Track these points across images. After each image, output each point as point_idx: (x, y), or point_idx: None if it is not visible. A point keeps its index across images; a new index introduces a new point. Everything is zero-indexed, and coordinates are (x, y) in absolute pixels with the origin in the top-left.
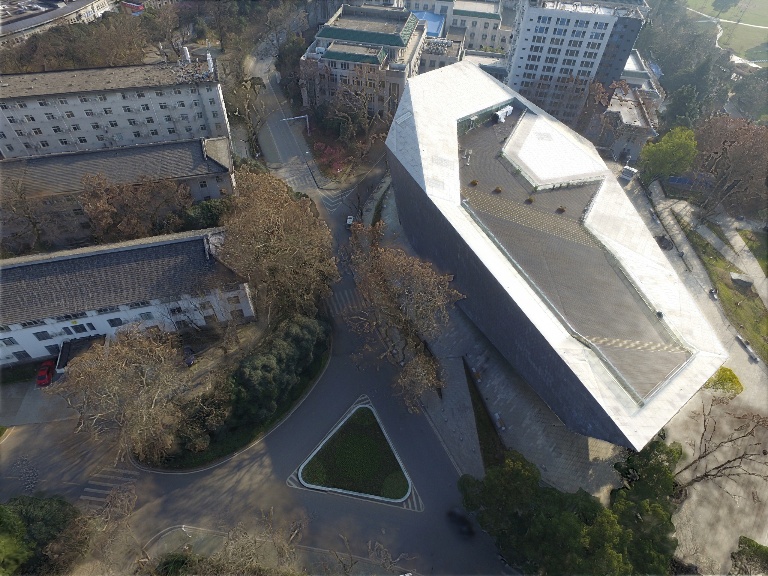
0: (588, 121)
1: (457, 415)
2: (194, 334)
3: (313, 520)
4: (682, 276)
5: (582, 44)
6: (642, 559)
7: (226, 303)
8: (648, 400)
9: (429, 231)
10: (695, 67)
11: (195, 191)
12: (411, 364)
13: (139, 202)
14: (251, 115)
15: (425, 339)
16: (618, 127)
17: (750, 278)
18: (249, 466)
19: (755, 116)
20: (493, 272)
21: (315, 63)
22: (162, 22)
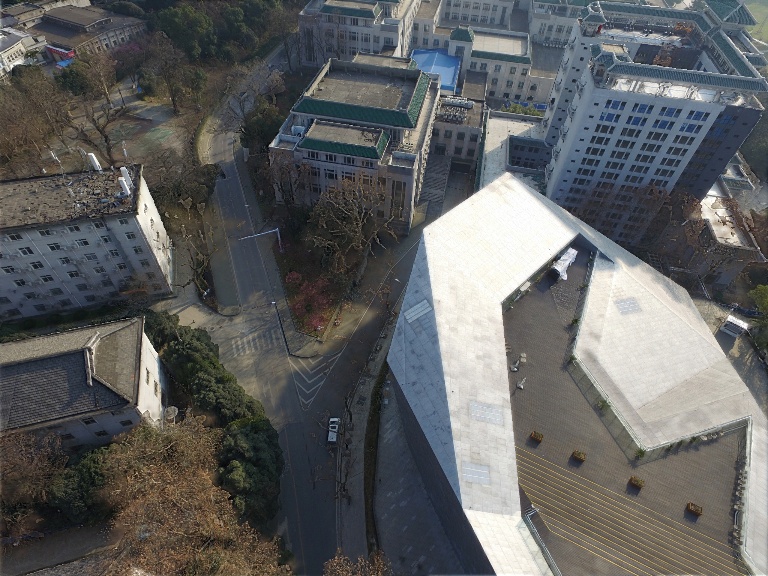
0: (662, 228)
1: None
2: None
3: None
4: None
5: (667, 137)
6: None
7: None
8: None
9: (462, 536)
10: None
11: (77, 429)
12: None
13: None
14: None
15: None
16: (710, 248)
17: None
18: None
19: None
20: None
21: (288, 158)
22: (92, 79)
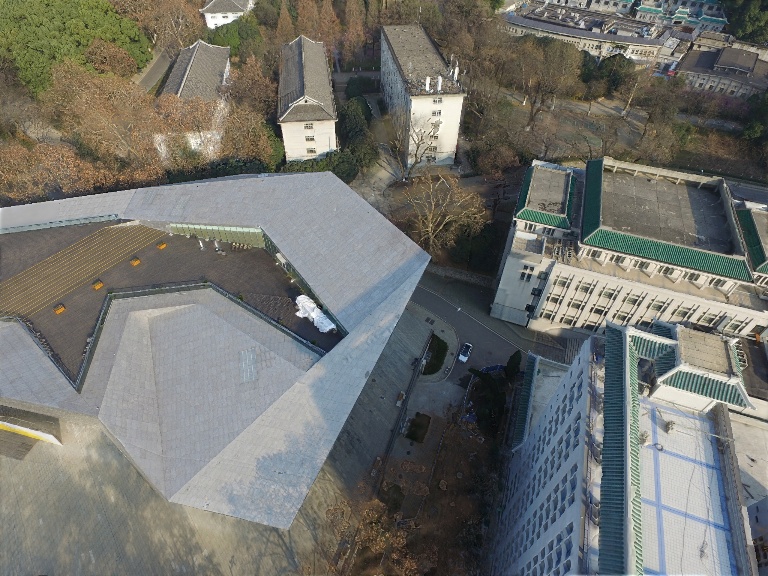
0: None
1: None
2: None
3: None
4: None
5: None
6: None
7: None
8: None
9: None
10: None
11: None
12: None
13: None
14: None
15: None
16: None
17: None
18: None
19: None
20: (5, 209)
21: (506, 163)
22: None
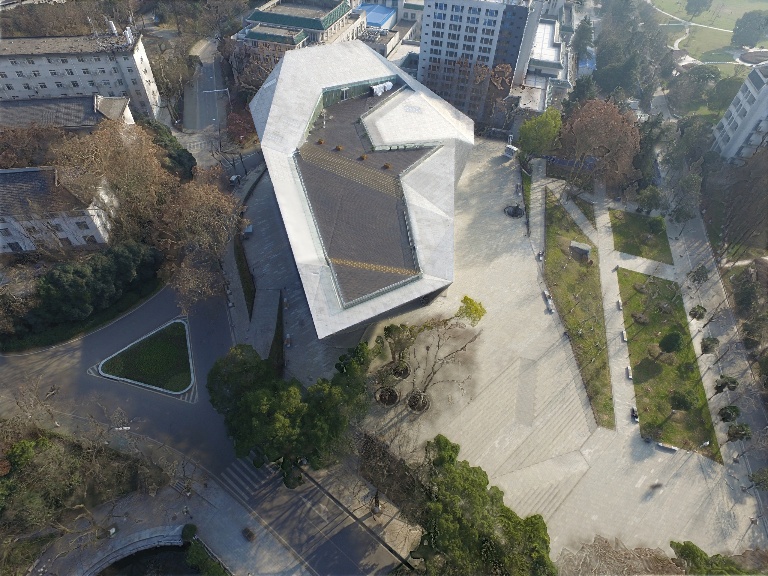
0: None
1: (259, 335)
2: (51, 254)
3: (98, 400)
4: (519, 240)
5: (477, 30)
6: (310, 428)
7: (76, 227)
8: (348, 303)
9: None
10: (624, 62)
11: None
12: (182, 271)
13: (18, 140)
14: (186, 89)
15: (254, 274)
16: (513, 110)
17: (587, 246)
18: (61, 356)
19: (683, 112)
20: (281, 206)
21: (236, 42)
22: (123, 5)
